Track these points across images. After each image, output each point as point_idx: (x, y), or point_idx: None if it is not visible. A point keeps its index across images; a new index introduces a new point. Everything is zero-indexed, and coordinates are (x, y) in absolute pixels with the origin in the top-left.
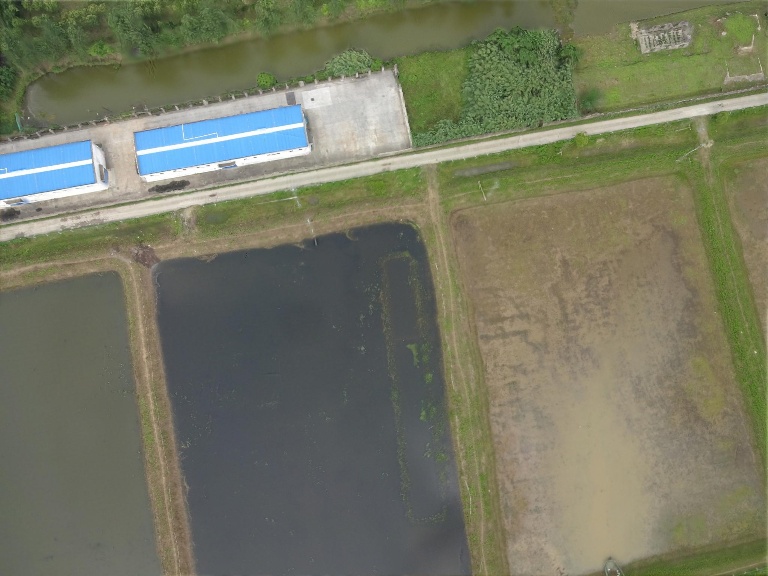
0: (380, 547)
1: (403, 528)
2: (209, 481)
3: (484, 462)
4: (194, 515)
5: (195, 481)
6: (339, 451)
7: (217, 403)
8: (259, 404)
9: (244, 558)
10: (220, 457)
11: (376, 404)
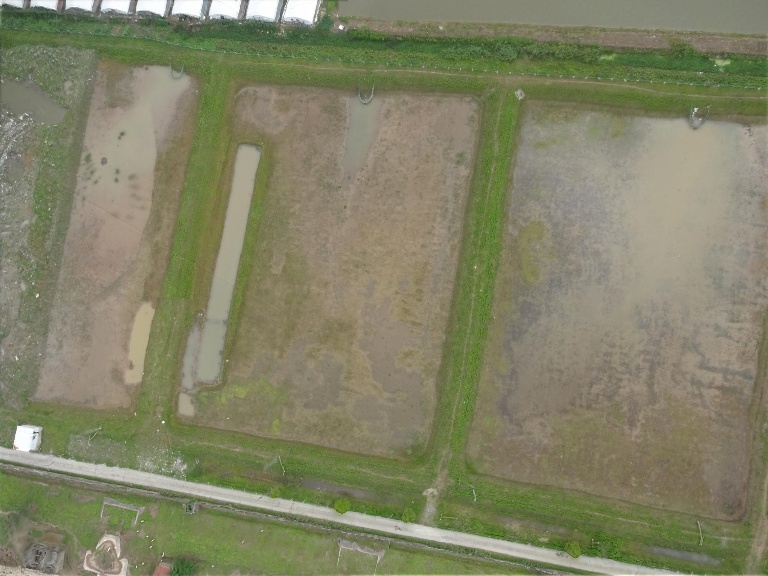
0: None
1: None
2: None
3: None
4: None
5: None
6: None
7: None
8: None
9: None
10: None
11: None
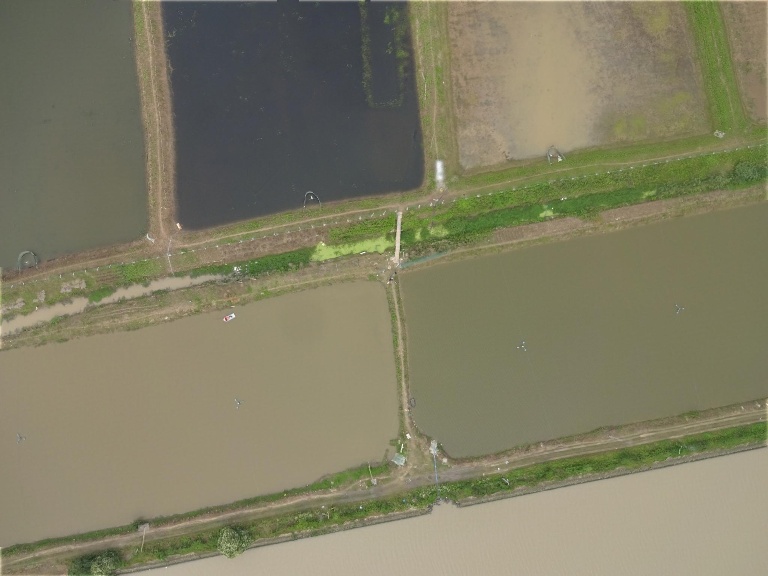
0: (341, 125)
1: (363, 110)
2: (191, 64)
3: (440, 58)
4: (176, 91)
5: (178, 64)
6: (309, 45)
7: (202, 1)
8: (239, 4)
9: (218, 128)
10: (202, 45)
11: (344, 8)
